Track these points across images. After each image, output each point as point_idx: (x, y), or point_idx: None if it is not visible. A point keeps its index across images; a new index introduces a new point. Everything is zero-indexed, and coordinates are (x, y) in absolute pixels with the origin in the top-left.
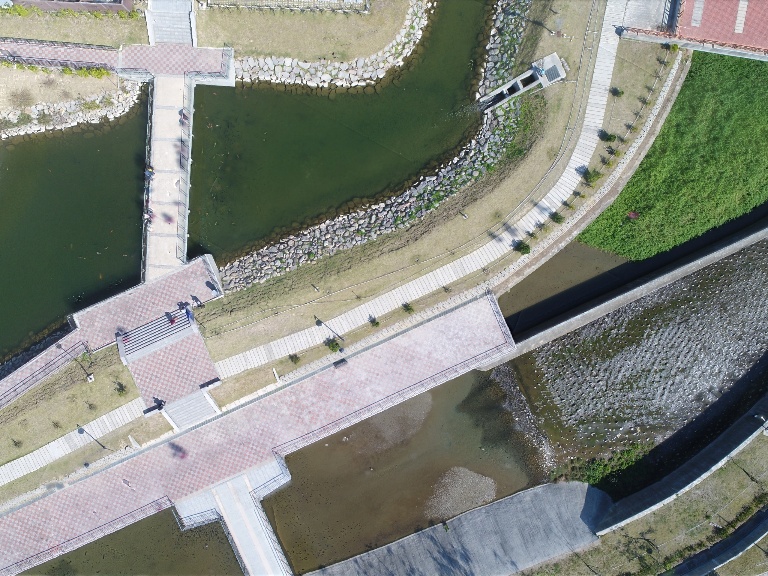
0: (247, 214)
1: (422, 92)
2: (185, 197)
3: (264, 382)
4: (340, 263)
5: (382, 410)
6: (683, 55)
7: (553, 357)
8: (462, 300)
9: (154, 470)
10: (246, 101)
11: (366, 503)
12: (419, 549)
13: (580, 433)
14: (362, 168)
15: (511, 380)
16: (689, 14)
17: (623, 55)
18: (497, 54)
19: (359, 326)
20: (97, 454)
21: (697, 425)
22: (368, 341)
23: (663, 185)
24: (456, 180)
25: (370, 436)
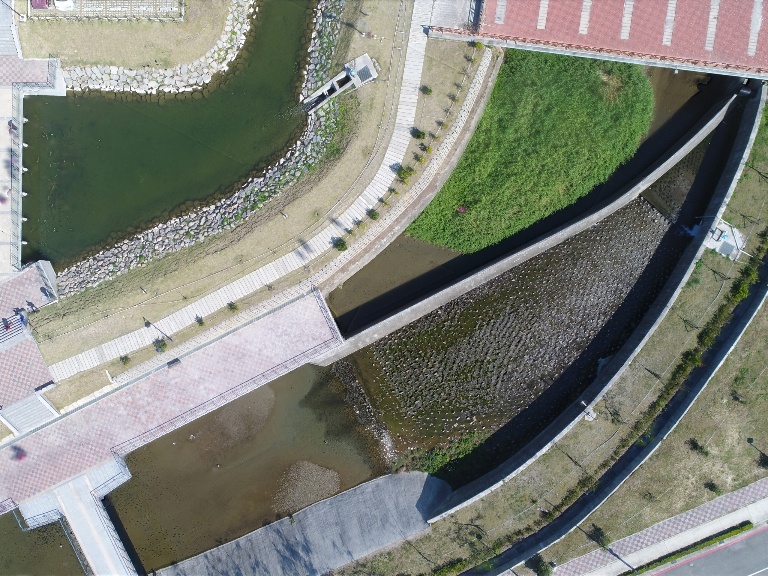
0: (84, 220)
1: (250, 96)
2: (17, 205)
3: (100, 384)
4: (168, 265)
5: (216, 407)
6: (494, 52)
7: (390, 350)
8: (289, 298)
9: None
10: (79, 110)
11: (215, 499)
12: (265, 542)
13: (419, 424)
14: (194, 172)
15: (350, 374)
16: (492, 12)
17: (431, 54)
18: (317, 56)
19: (187, 326)
20: None
21: (530, 412)
22: (198, 340)
23: (488, 179)
24: (280, 181)
25: (216, 433)
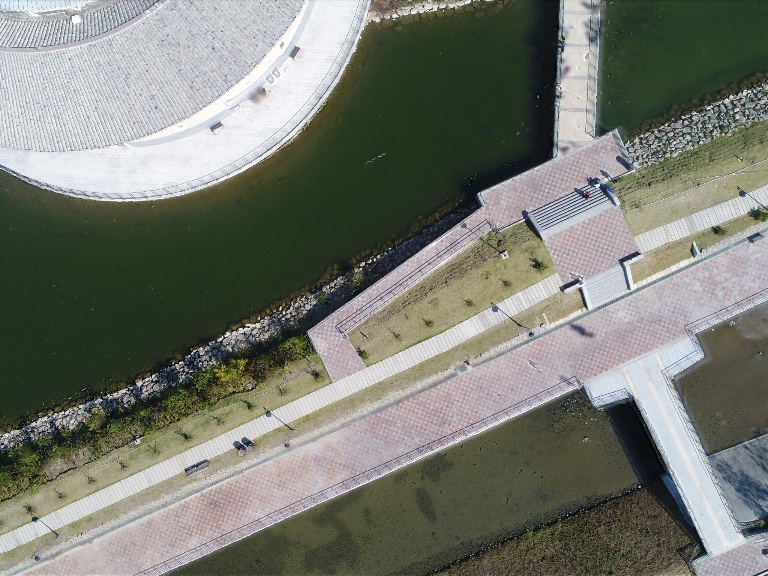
0: (642, 92)
1: None
2: (595, 71)
3: (678, 257)
4: (760, 133)
5: None
6: None
7: None
8: None
9: (561, 350)
10: None
11: (754, 388)
12: None
13: None
14: (761, 43)
15: None
16: None
17: None
18: None
19: None
20: (512, 332)
21: None
22: None
23: None
24: None
25: (758, 320)
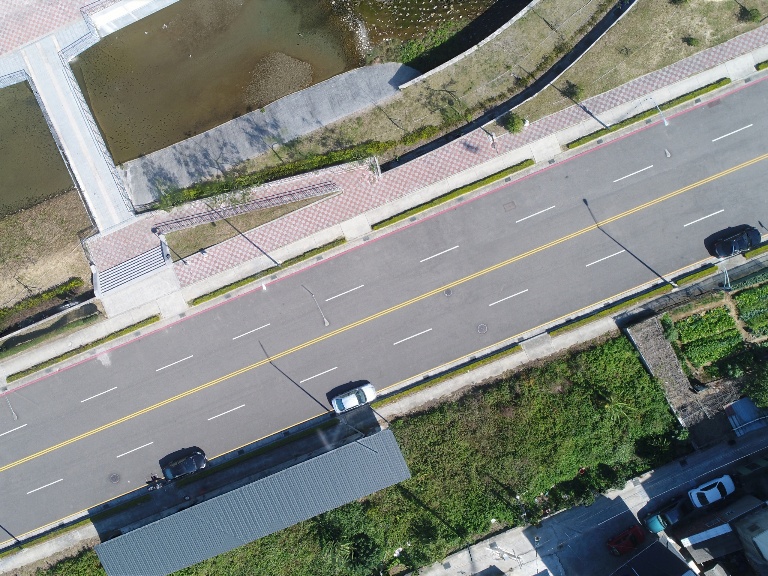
0: None
1: None
2: None
3: None
4: None
5: None
6: None
7: None
8: None
9: None
10: None
11: (185, 91)
12: (234, 129)
13: (395, 14)
14: None
15: None
16: None
17: None
18: None
19: None
20: None
21: (509, 0)
22: None
23: None
24: None
25: (189, 23)
